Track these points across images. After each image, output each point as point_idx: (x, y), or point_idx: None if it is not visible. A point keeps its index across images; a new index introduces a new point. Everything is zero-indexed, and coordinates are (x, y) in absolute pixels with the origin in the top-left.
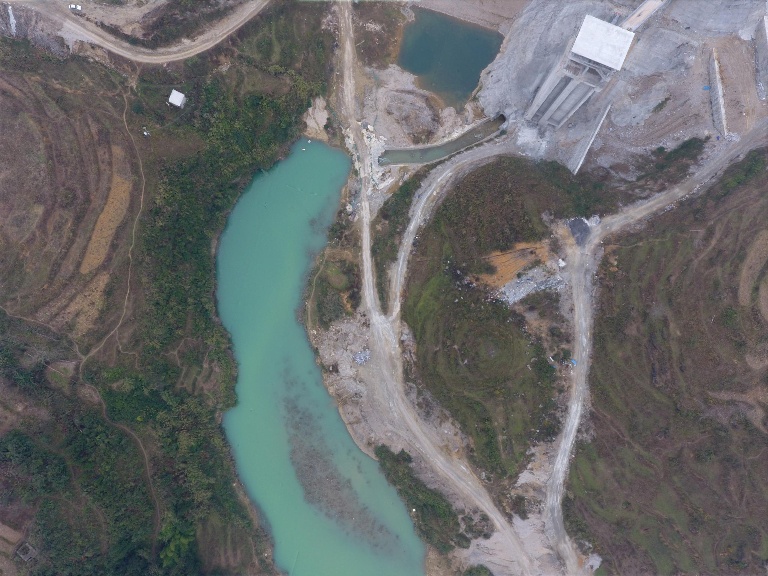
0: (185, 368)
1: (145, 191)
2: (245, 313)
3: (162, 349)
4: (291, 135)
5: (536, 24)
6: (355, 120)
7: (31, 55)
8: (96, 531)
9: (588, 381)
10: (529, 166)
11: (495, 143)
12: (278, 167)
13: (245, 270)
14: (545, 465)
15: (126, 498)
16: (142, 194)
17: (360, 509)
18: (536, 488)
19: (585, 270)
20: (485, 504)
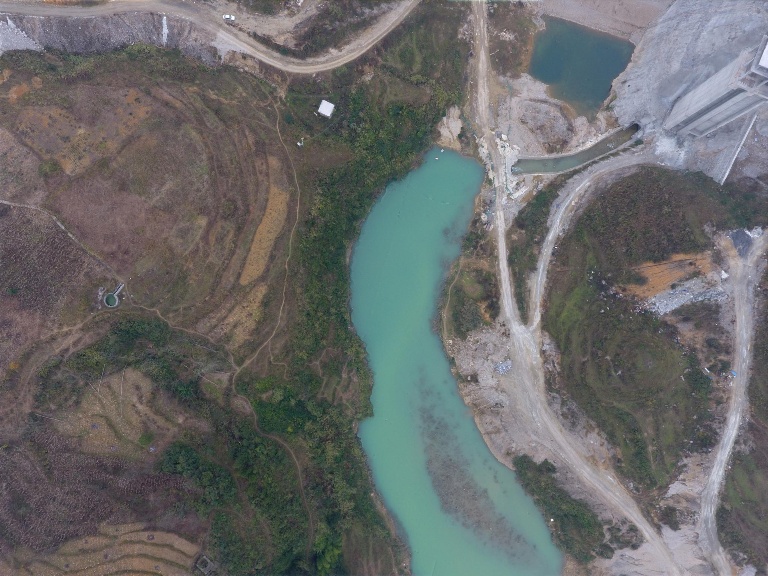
0: (326, 378)
1: (301, 202)
2: (377, 322)
3: (307, 359)
4: (426, 144)
5: (680, 34)
6: (489, 129)
7: (187, 65)
8: (264, 543)
9: (748, 392)
10: (679, 177)
11: (633, 153)
12: (408, 176)
13: (377, 279)
14: (700, 476)
15: (287, 510)
16: (298, 205)
17: (497, 519)
18: (689, 499)
19: (747, 282)
20: (633, 515)
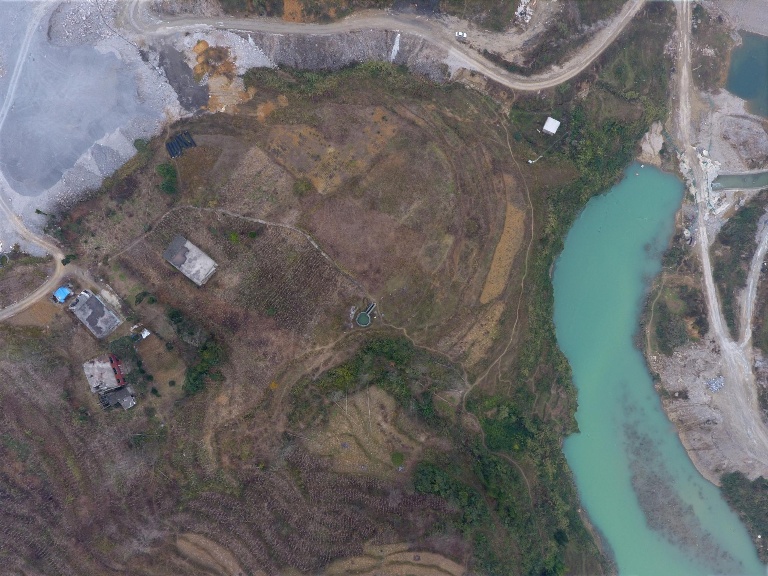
0: (538, 394)
1: (535, 220)
2: (575, 338)
3: None
4: (629, 160)
5: None
6: (690, 145)
7: (423, 83)
8: None
9: None
10: None
11: None
12: None
13: (576, 295)
14: None
15: (529, 529)
16: (532, 223)
17: (703, 535)
18: None
19: None
20: None
